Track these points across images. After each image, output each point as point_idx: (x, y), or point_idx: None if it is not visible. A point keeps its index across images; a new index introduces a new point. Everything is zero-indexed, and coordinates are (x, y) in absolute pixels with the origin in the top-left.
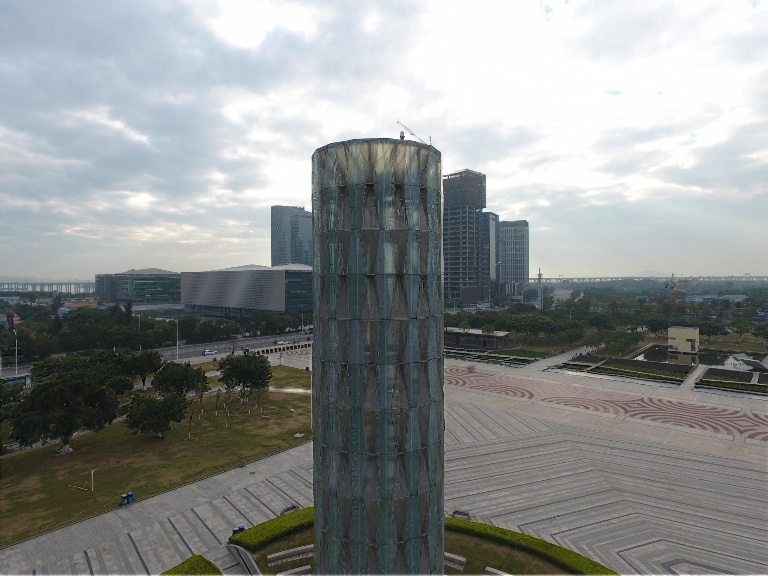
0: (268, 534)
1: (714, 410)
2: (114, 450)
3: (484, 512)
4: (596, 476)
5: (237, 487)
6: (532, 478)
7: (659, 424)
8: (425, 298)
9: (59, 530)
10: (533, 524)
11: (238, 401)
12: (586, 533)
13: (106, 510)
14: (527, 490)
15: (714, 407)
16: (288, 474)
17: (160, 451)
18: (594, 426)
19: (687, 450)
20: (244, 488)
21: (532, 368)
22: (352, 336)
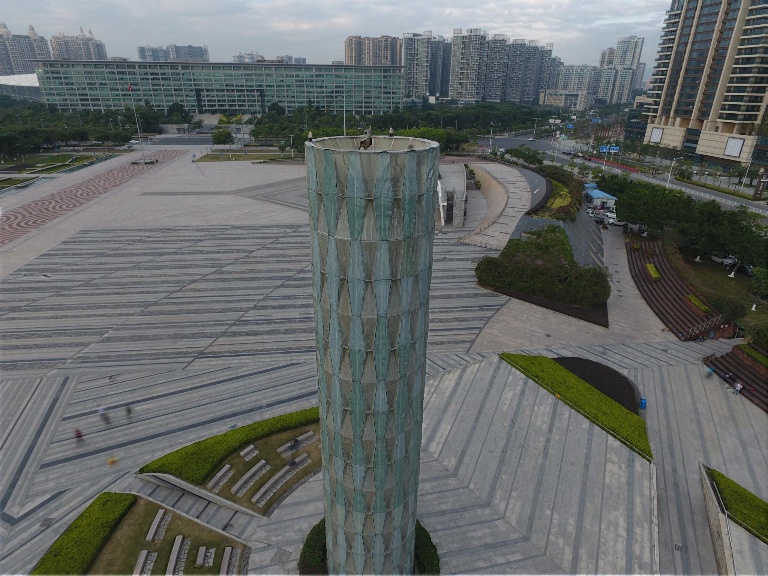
0: None
1: None
2: None
3: None
4: None
5: None
6: None
7: None
8: None
9: None
10: None
11: None
12: None
13: None
14: None
15: None
16: None
17: None
18: None
19: None
20: None
21: None
22: None
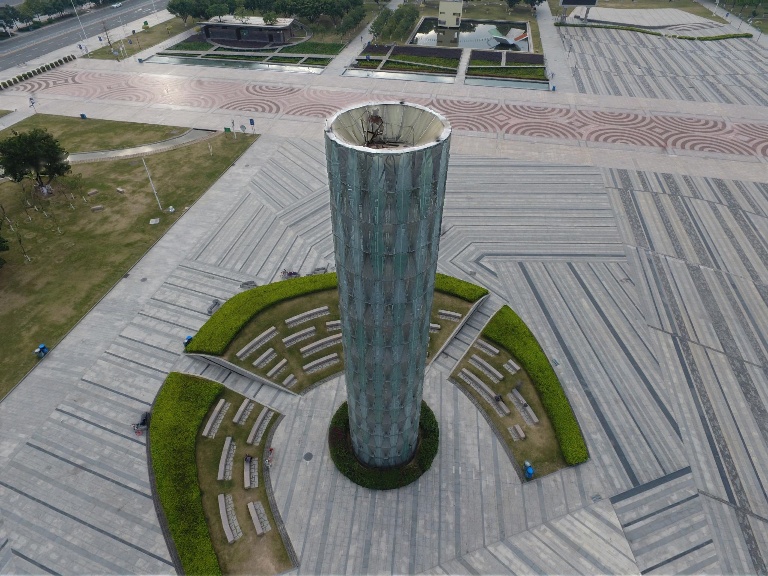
0: (225, 339)
1: (482, 106)
2: None
3: None
4: None
5: (143, 299)
6: None
7: None
8: None
9: (2, 404)
10: None
11: (37, 191)
12: None
13: (29, 368)
14: None
15: (482, 102)
16: (181, 270)
17: (11, 286)
18: None
19: (472, 156)
20: (151, 298)
21: (332, 72)
22: (396, 289)
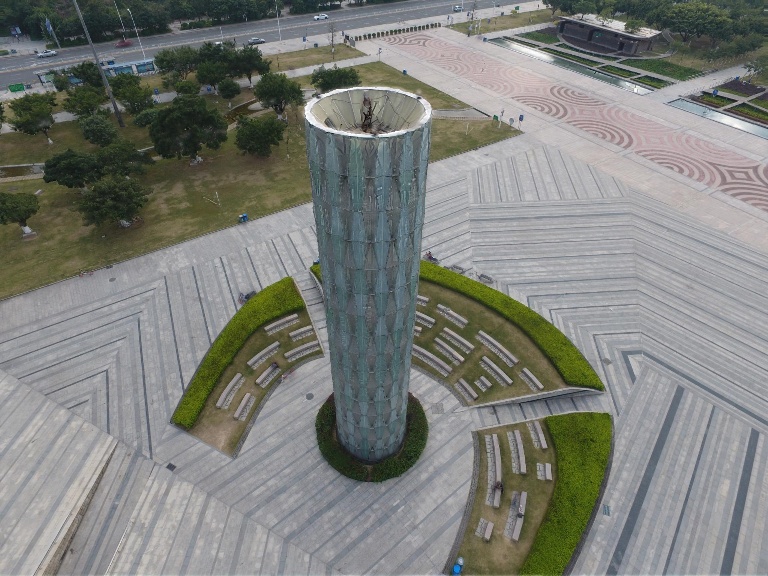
0: None
1: None
2: (231, 164)
3: (506, 278)
4: (628, 260)
5: None
6: (567, 252)
7: (746, 207)
8: (395, 253)
9: (203, 237)
10: (541, 297)
11: None
12: (580, 314)
13: (230, 225)
14: (555, 264)
15: None
16: None
17: (266, 170)
18: (670, 199)
19: (747, 246)
20: None
21: (658, 97)
22: (337, 272)
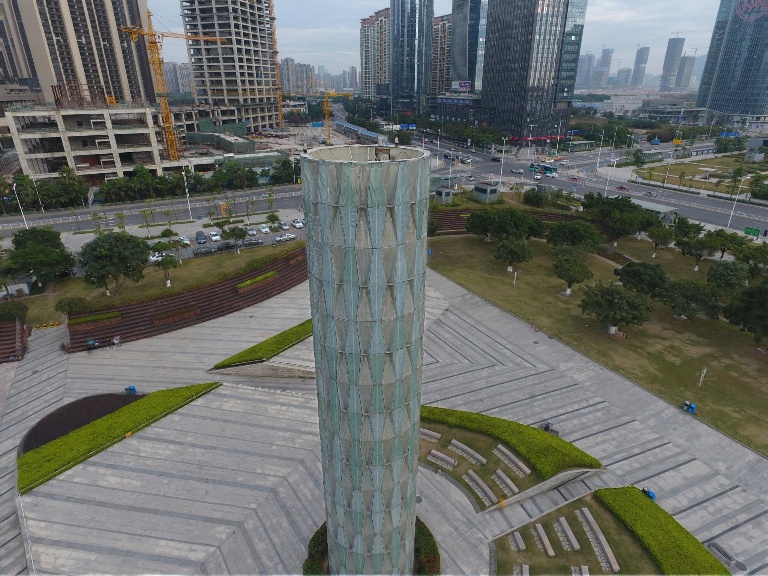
0: (617, 505)
1: None
2: None
3: None
4: None
5: None
6: None
7: None
8: None
9: (630, 383)
10: None
11: None
12: None
13: (669, 400)
14: None
15: None
16: None
17: None
18: None
19: None
20: None
21: None
22: None
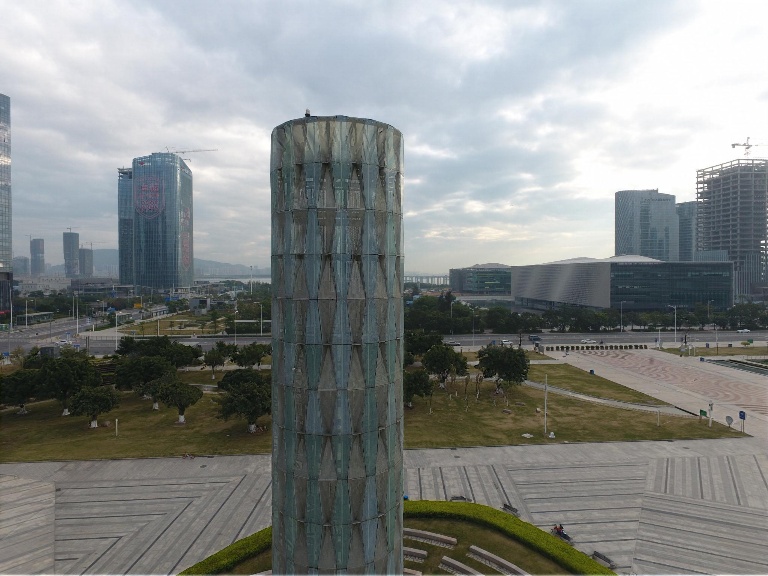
0: (410, 509)
1: None
2: None
3: None
4: None
5: (435, 464)
6: None
7: None
8: (332, 279)
9: None
10: None
11: (495, 391)
12: None
13: None
14: None
15: None
16: (487, 468)
17: None
18: None
19: None
20: (440, 467)
21: None
22: (275, 313)
